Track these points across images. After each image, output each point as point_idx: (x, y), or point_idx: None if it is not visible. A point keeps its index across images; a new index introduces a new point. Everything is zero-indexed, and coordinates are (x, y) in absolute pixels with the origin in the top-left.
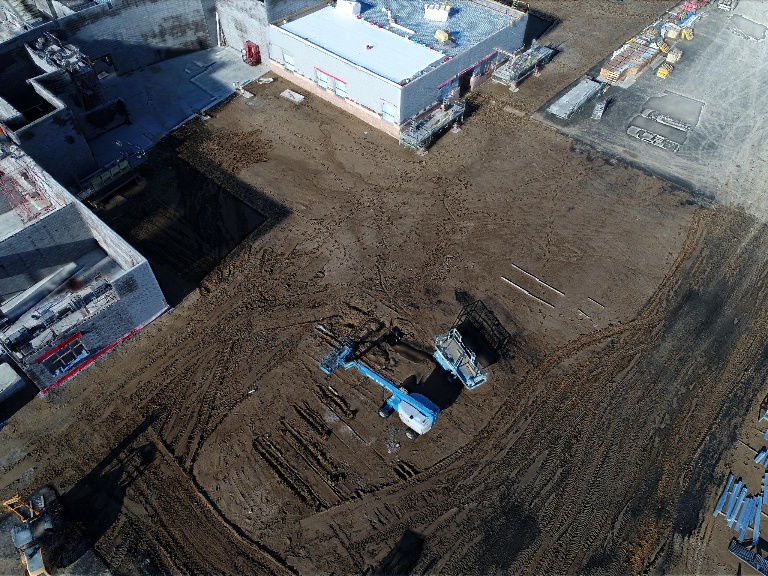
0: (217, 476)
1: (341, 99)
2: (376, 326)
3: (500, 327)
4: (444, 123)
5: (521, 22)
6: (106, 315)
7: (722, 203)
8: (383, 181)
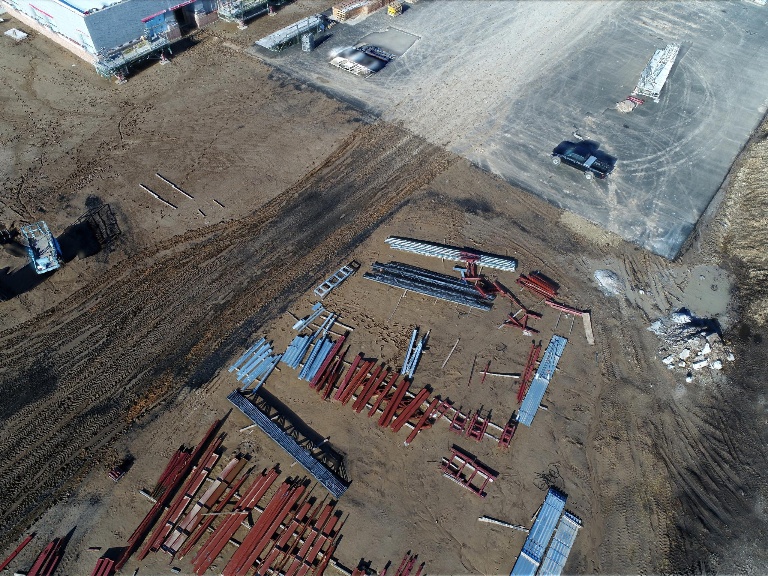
0: None
1: (56, 35)
2: None
3: (115, 226)
4: (142, 53)
5: None
6: None
7: (385, 120)
8: (69, 106)
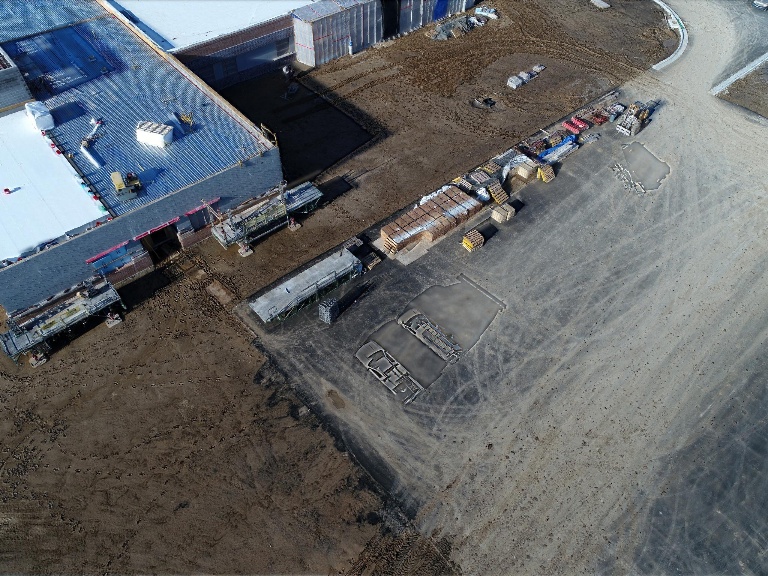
0: None
1: None
2: None
3: None
4: (74, 320)
5: (265, 158)
6: None
7: (421, 529)
8: None
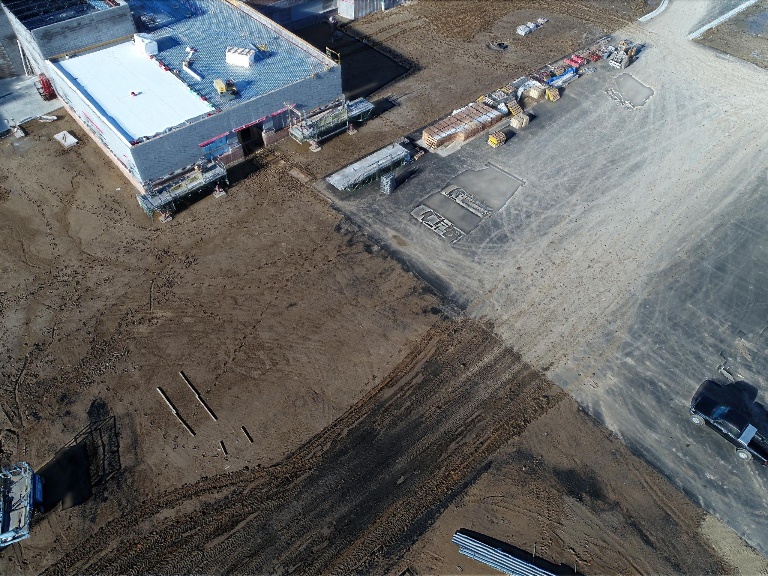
0: None
1: (106, 148)
2: None
3: (115, 456)
4: (194, 187)
5: (330, 73)
6: None
7: (471, 316)
8: (101, 250)
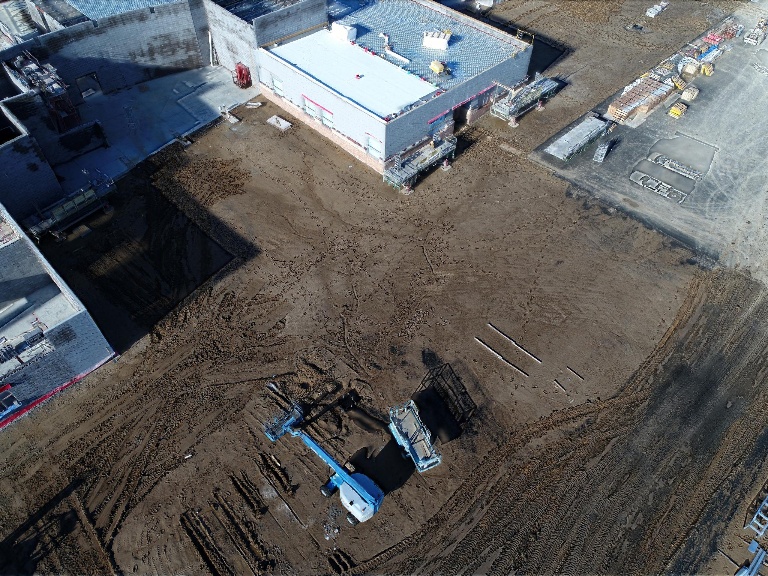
0: (137, 554)
1: (328, 129)
2: (332, 387)
3: (466, 396)
4: (432, 161)
5: (525, 54)
6: (40, 366)
7: (726, 264)
8: (362, 221)
